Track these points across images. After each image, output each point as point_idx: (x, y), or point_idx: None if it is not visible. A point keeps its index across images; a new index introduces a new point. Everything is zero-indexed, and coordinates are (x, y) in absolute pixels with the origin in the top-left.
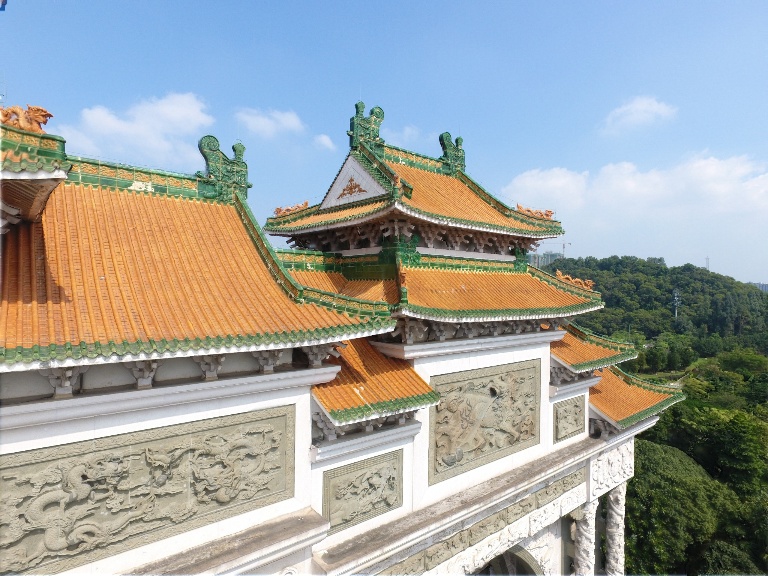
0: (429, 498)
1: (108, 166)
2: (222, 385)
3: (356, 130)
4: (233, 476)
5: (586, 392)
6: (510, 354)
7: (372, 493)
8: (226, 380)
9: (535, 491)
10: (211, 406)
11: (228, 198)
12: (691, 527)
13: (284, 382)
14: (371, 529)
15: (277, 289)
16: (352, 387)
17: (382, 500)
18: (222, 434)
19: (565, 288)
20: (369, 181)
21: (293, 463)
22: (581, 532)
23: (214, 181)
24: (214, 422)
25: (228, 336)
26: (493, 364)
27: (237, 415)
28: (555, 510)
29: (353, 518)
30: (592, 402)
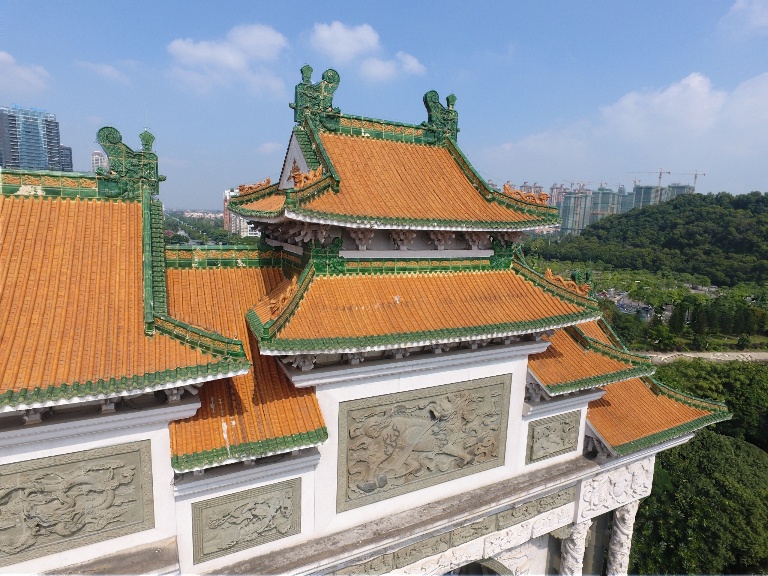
0: (337, 525)
1: None
2: (39, 431)
3: (300, 101)
4: (73, 512)
5: (583, 407)
6: (463, 371)
7: (257, 523)
8: (44, 426)
9: (496, 513)
10: (40, 446)
11: (135, 195)
12: (736, 547)
13: (125, 422)
14: (258, 555)
15: (140, 314)
16: (222, 421)
17: None
18: (59, 472)
19: (554, 291)
20: (305, 166)
21: (152, 496)
22: (567, 549)
23: (116, 178)
24: (47, 461)
25: (21, 390)
26: (436, 384)
27: (75, 453)
28: (523, 532)
29: (233, 546)
30: (590, 418)
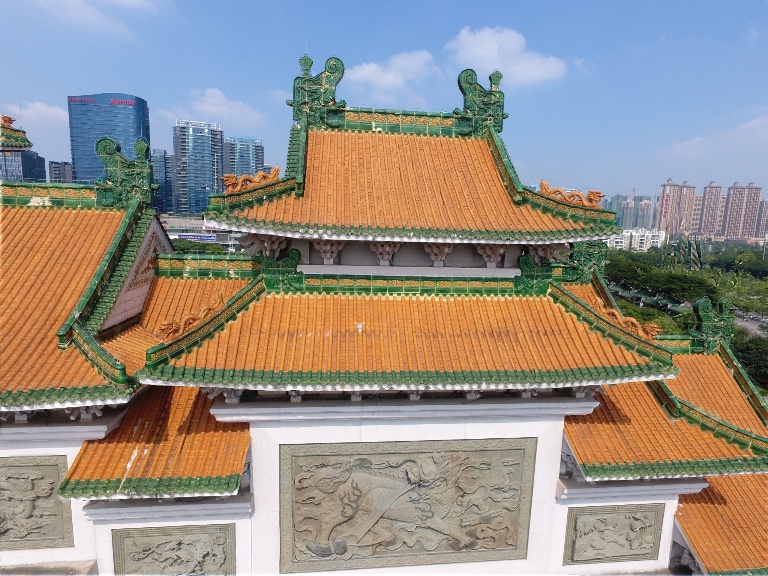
0: None
1: (8, 185)
2: None
3: (297, 97)
4: None
5: (669, 499)
6: (456, 426)
7: (182, 565)
8: None
9: None
10: None
11: (129, 204)
12: None
13: (33, 435)
14: None
15: None
16: (136, 448)
17: (202, 574)
18: None
19: (605, 331)
20: None
21: (71, 514)
22: None
23: (112, 187)
24: None
25: None
26: (415, 438)
27: None
28: None
29: None
30: (679, 519)
